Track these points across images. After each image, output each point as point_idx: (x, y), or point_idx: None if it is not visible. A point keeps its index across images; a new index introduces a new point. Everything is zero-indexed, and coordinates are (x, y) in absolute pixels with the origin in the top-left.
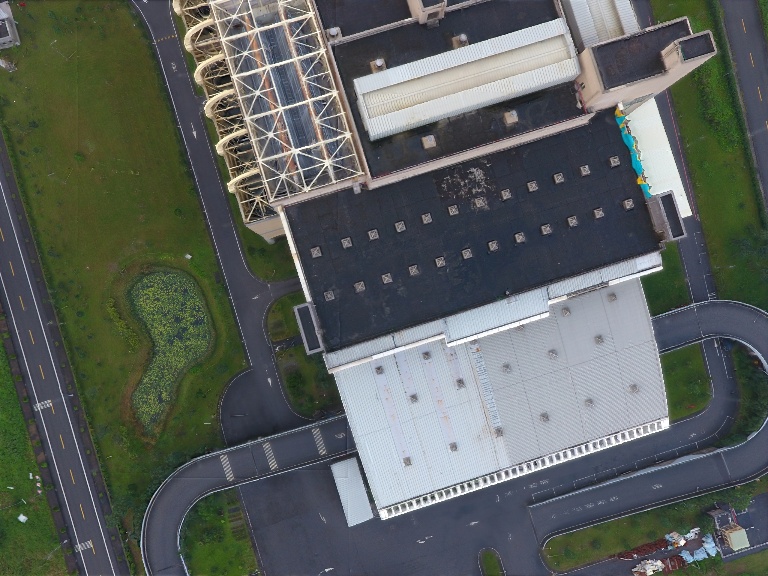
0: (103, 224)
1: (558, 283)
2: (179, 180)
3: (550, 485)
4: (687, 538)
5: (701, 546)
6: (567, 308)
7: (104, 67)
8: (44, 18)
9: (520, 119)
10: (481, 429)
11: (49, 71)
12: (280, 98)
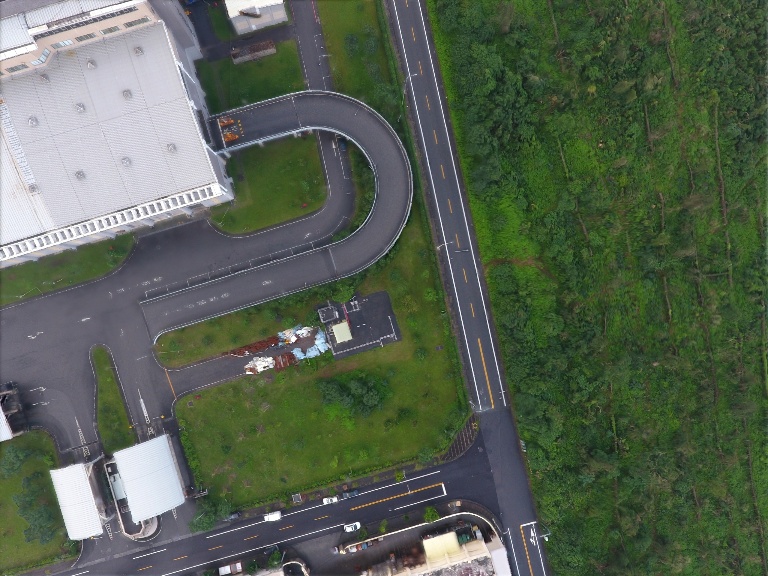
0: None
1: (35, 11)
2: None
3: (163, 283)
4: (300, 336)
5: (314, 344)
6: (91, 60)
7: None
8: None
9: None
10: (15, 185)
11: None
12: None
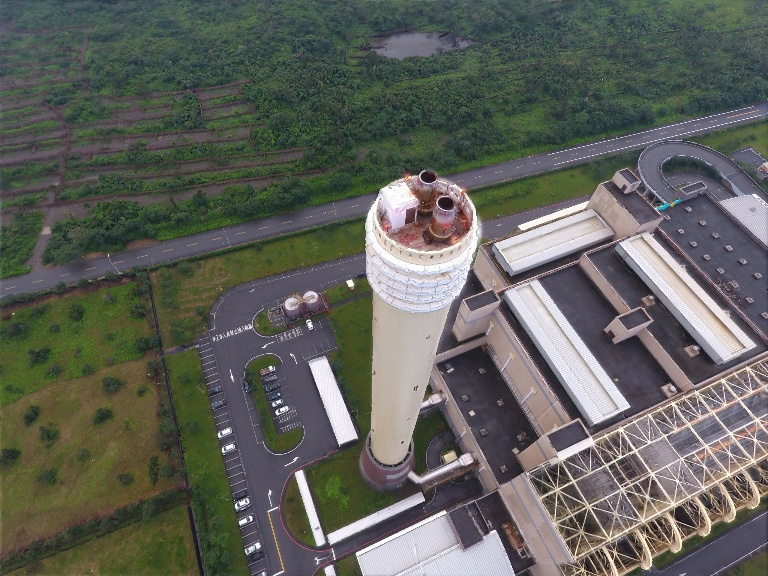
0: None
1: None
2: None
3: None
4: None
5: None
6: None
7: None
8: None
9: None
10: None
11: None
12: None
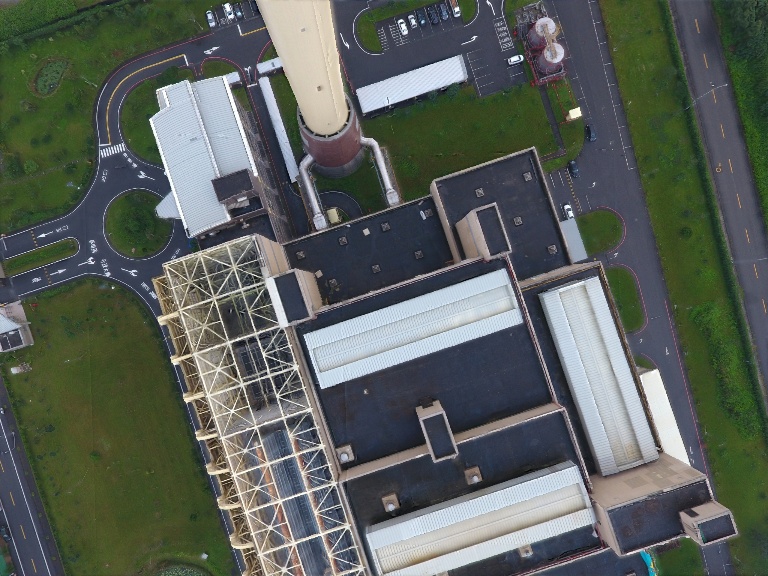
0: (120, 522)
1: None
2: (193, 477)
3: None
4: None
5: None
6: None
7: (116, 365)
8: (56, 317)
9: (535, 548)
10: None
11: (63, 370)
12: (292, 513)
